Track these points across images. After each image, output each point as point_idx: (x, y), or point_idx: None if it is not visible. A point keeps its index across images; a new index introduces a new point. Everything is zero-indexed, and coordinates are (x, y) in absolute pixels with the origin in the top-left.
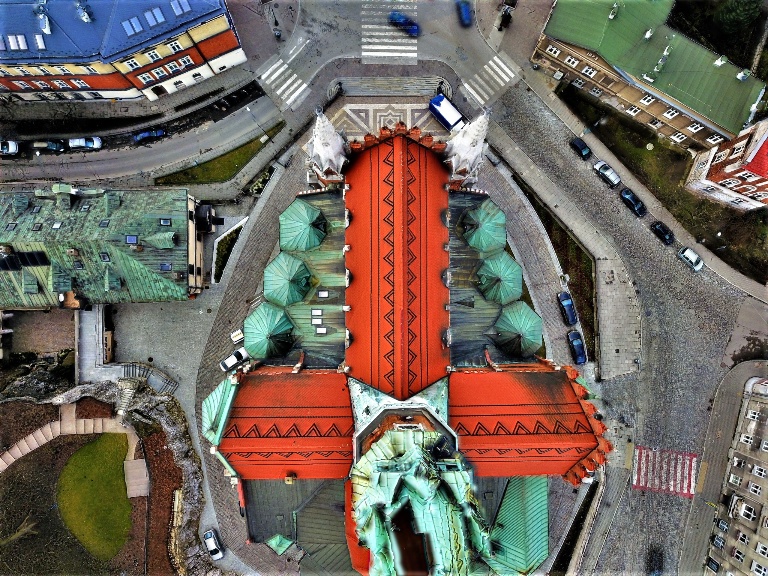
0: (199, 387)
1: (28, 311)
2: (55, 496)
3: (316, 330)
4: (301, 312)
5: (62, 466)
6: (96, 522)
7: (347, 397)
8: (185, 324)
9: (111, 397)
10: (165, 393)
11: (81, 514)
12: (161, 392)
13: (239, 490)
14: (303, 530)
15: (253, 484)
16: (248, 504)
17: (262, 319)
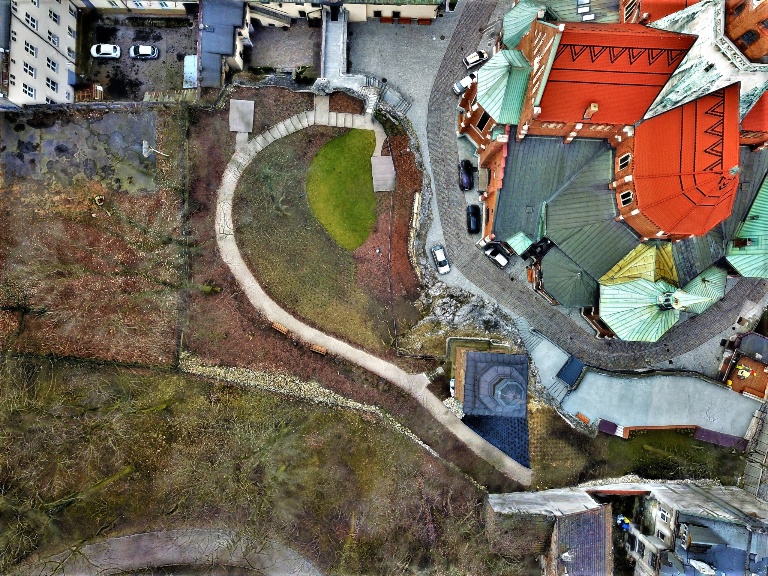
0: (431, 109)
1: (268, 28)
2: (305, 185)
3: (583, 18)
4: (565, 4)
5: (313, 157)
6: (343, 212)
7: (656, 29)
8: (419, 49)
9: (360, 97)
10: (400, 110)
11: (329, 204)
12: (396, 109)
13: (503, 165)
14: (555, 218)
15: (514, 164)
16: (502, 190)
17: (526, 9)
